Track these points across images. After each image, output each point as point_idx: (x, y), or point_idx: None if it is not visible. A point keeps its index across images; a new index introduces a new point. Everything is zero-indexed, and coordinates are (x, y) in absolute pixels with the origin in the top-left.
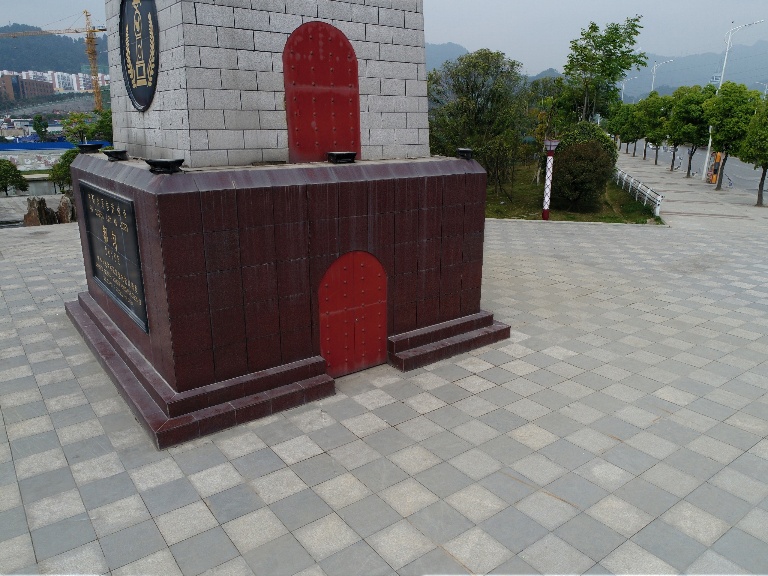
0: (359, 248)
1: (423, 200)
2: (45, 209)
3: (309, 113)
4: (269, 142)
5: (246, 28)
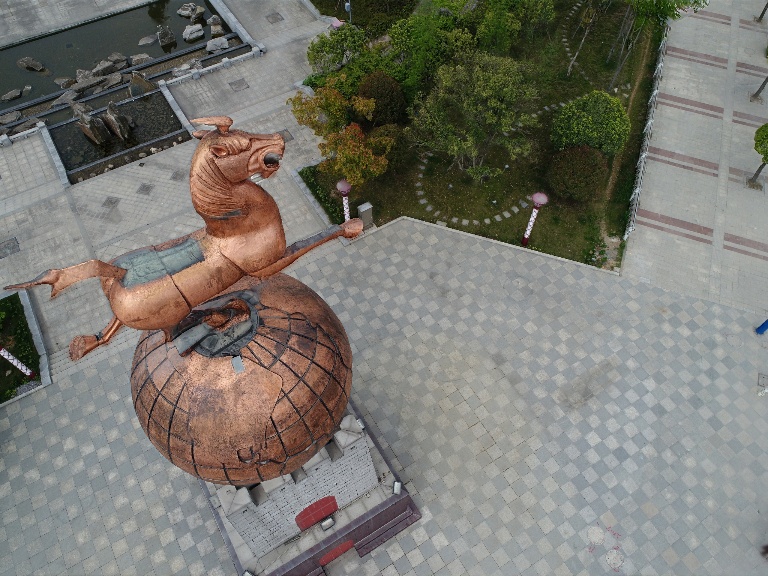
0: None
1: None
2: (96, 126)
3: None
4: (291, 535)
5: None
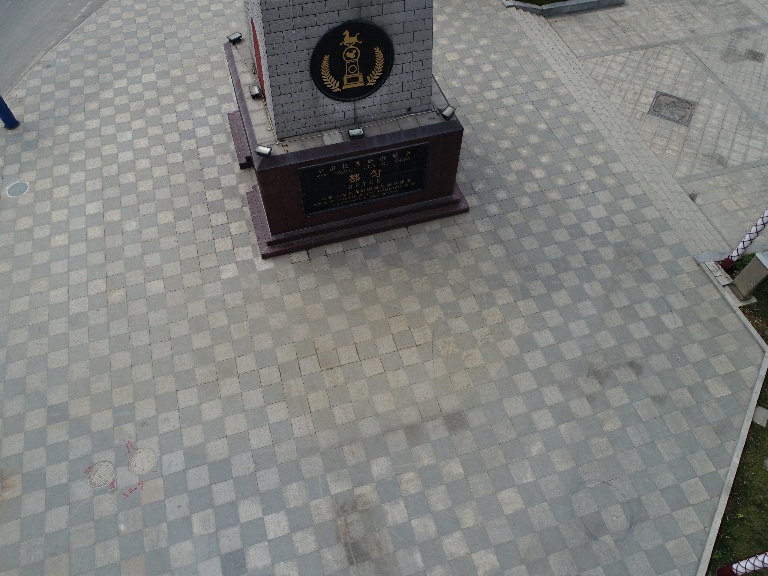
0: None
1: None
2: None
3: None
4: None
5: None
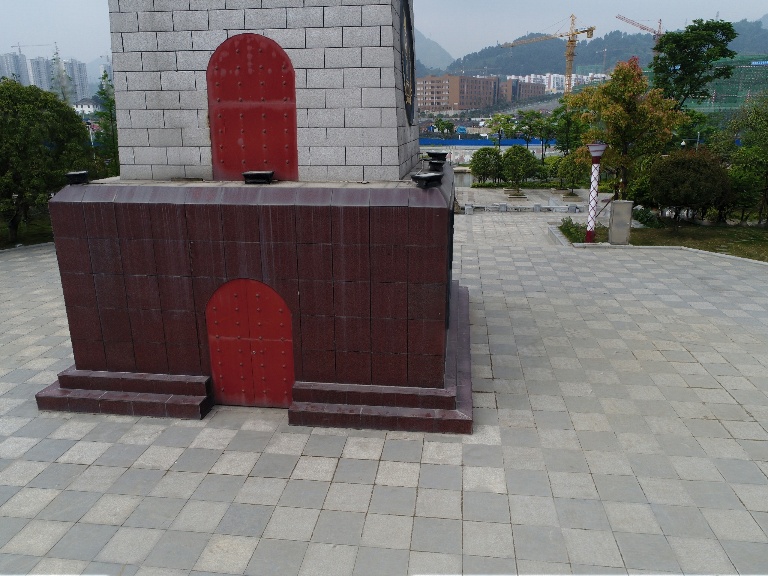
0: (251, 276)
1: (339, 234)
2: None
3: (236, 130)
4: (192, 159)
5: (169, 50)
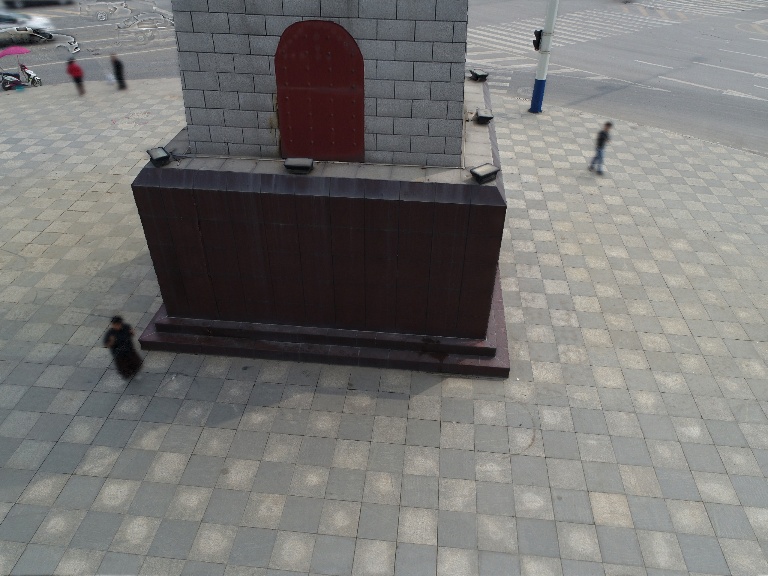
0: None
1: None
2: None
3: None
4: None
5: None
